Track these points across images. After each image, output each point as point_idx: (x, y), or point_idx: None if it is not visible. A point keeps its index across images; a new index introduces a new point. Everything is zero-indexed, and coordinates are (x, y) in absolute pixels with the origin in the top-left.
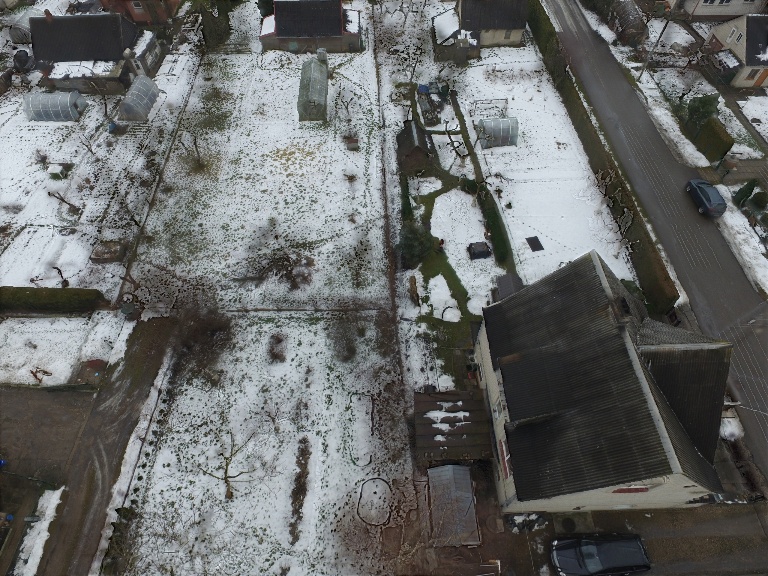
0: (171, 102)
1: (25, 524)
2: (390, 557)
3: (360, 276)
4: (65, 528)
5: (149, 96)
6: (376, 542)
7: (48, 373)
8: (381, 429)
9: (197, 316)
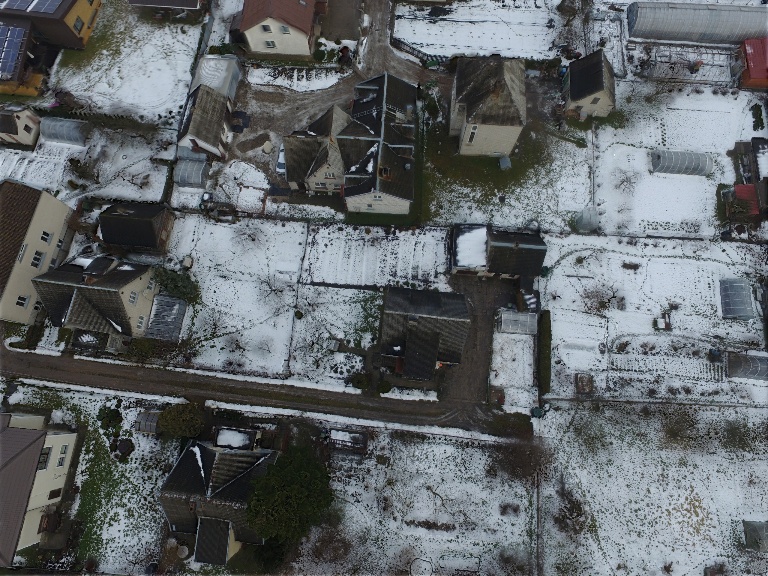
0: (759, 393)
1: (423, 388)
2: (396, 574)
3: (566, 570)
4: (420, 407)
5: (760, 377)
6: (403, 567)
7: (496, 377)
8: (458, 575)
9: (534, 453)
